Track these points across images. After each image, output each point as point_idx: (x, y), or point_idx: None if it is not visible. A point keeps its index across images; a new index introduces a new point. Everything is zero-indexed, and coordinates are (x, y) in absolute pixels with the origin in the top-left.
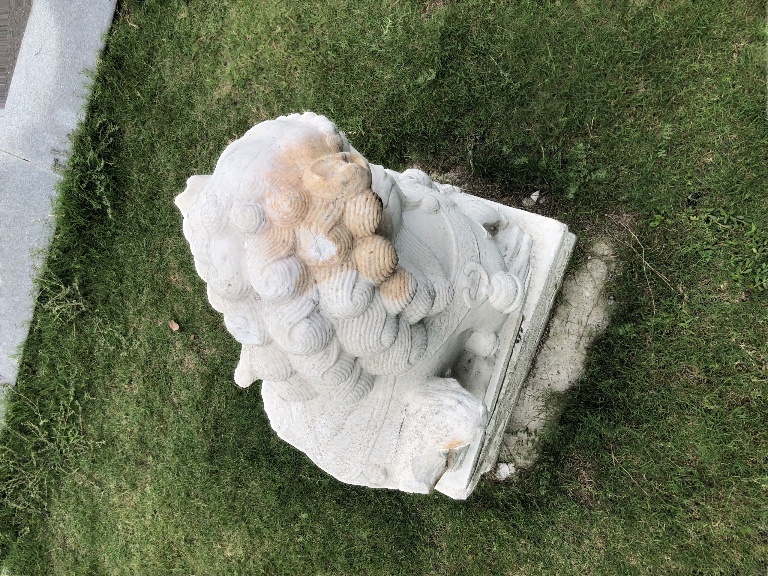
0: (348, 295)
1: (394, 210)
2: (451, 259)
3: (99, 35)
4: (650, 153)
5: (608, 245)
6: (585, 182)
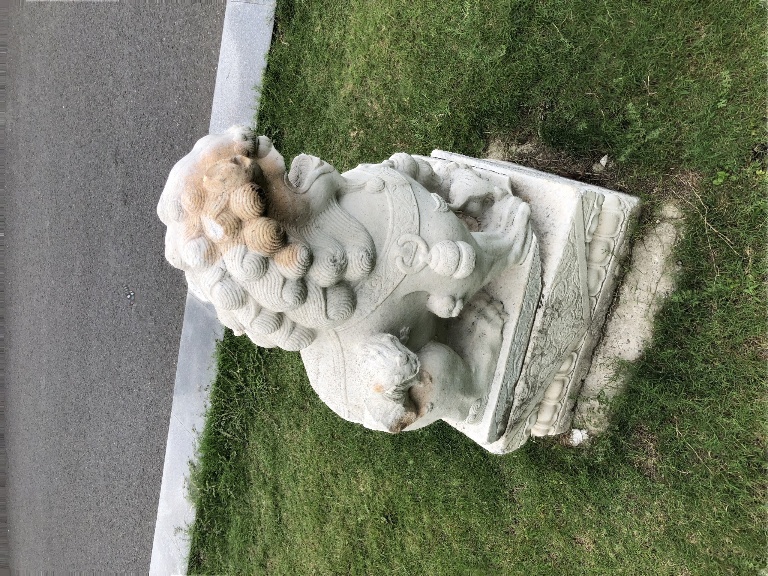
0: (239, 264)
1: (315, 194)
2: (386, 232)
3: (263, 56)
4: (710, 104)
5: (677, 207)
6: (645, 142)
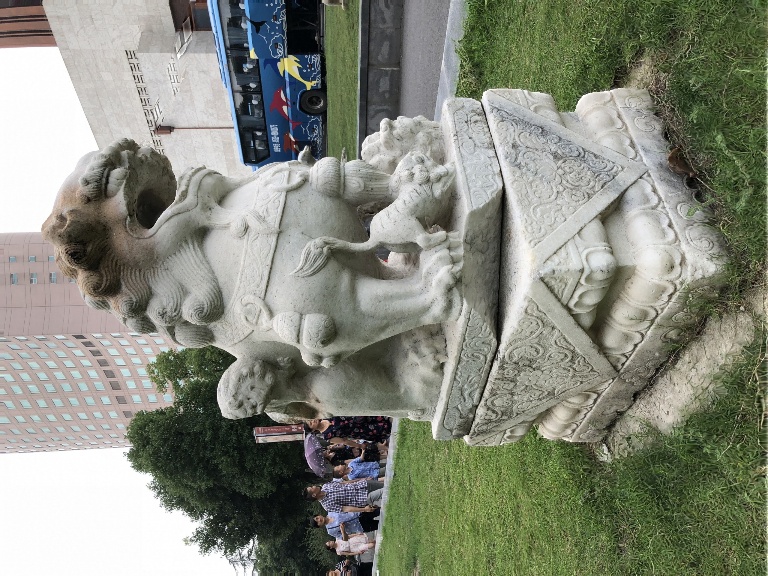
0: None
1: (161, 239)
2: (234, 285)
3: None
4: None
5: None
6: None
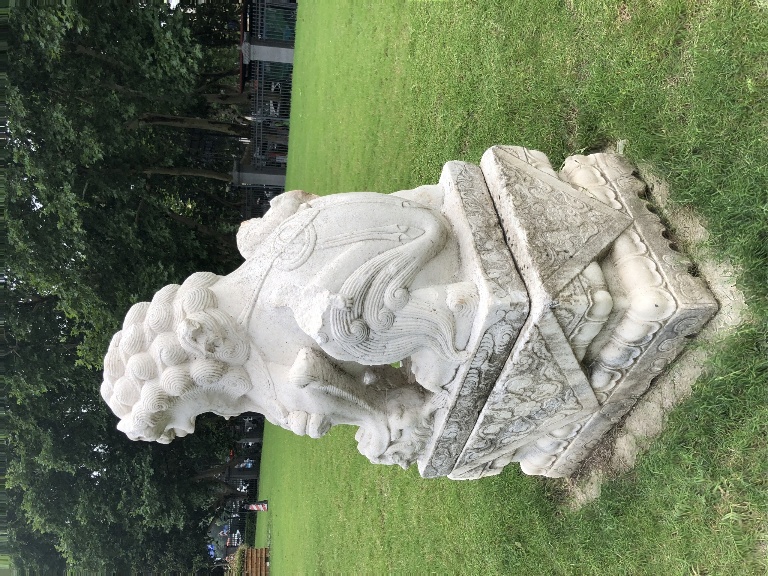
0: None
1: None
2: None
3: None
4: None
5: None
6: None
